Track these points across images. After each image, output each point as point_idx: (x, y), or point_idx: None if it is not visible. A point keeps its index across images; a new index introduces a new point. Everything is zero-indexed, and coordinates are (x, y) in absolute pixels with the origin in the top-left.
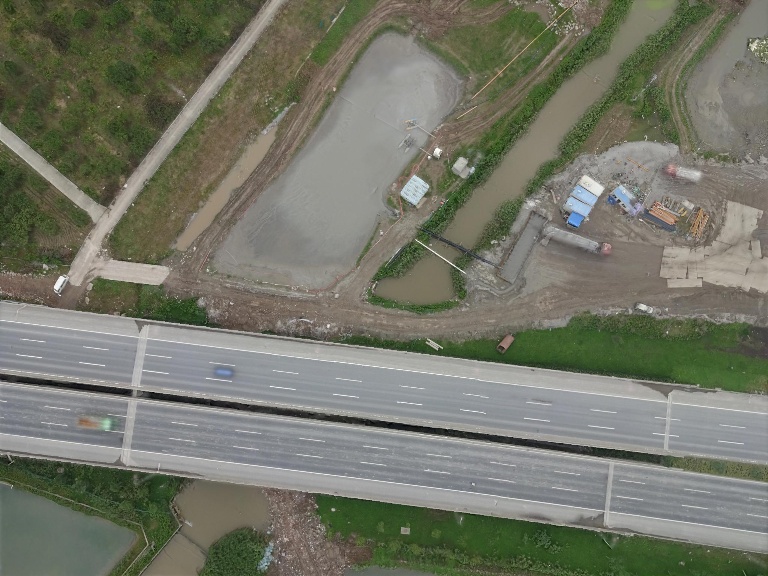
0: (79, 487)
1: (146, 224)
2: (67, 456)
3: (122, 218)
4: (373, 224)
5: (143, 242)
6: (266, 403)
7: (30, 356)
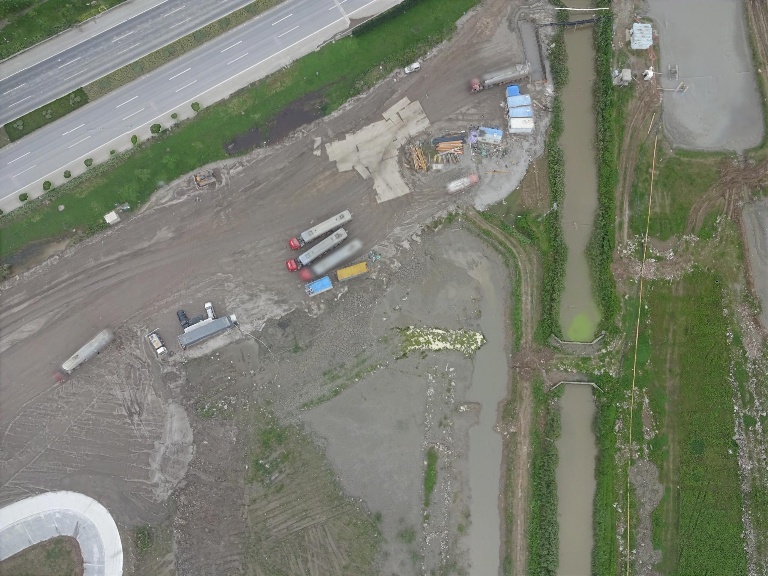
0: None
1: None
2: None
3: None
4: None
5: None
6: None
7: None
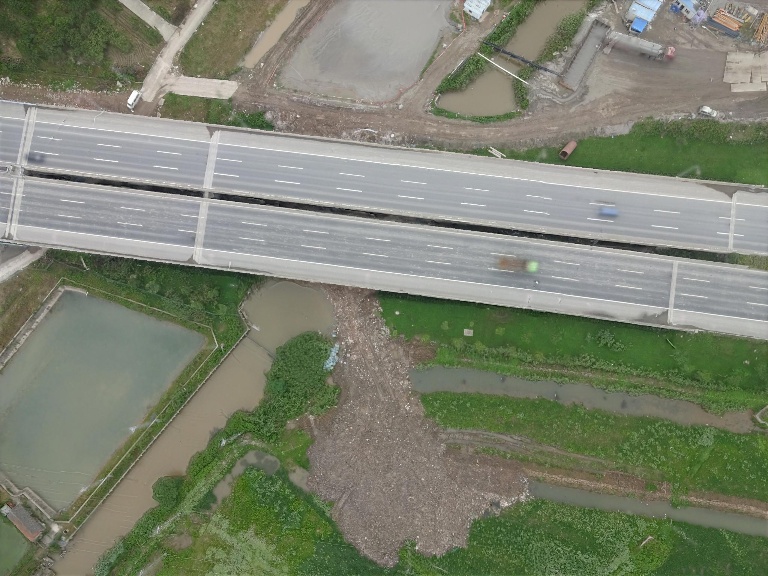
0: (153, 287)
1: (215, 43)
2: (142, 254)
3: (192, 36)
4: (436, 39)
5: (212, 60)
6: (333, 204)
7: (107, 160)
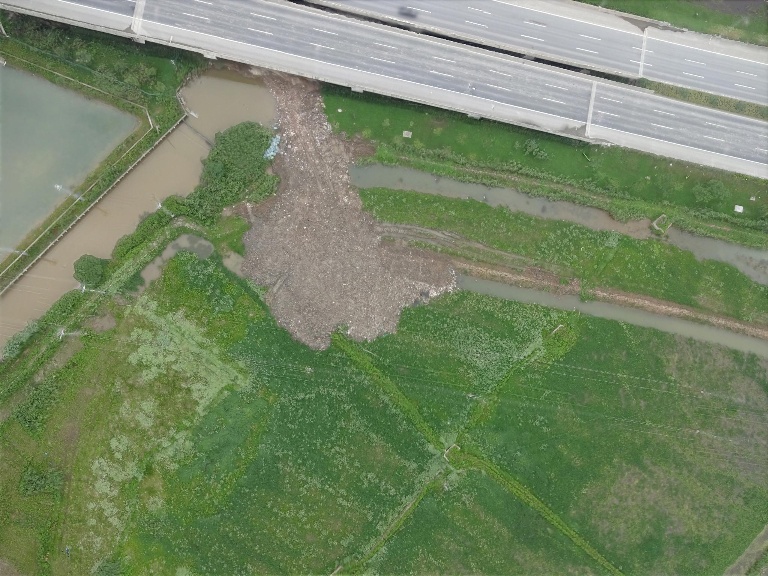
0: (84, 56)
1: None
2: (74, 18)
3: None
4: None
5: None
6: None
7: None
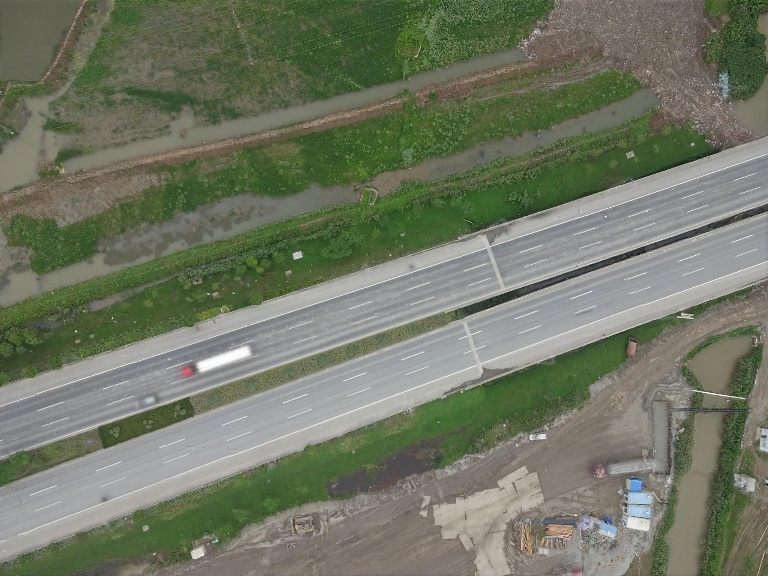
0: None
1: None
2: None
3: None
4: None
5: None
6: None
7: None
